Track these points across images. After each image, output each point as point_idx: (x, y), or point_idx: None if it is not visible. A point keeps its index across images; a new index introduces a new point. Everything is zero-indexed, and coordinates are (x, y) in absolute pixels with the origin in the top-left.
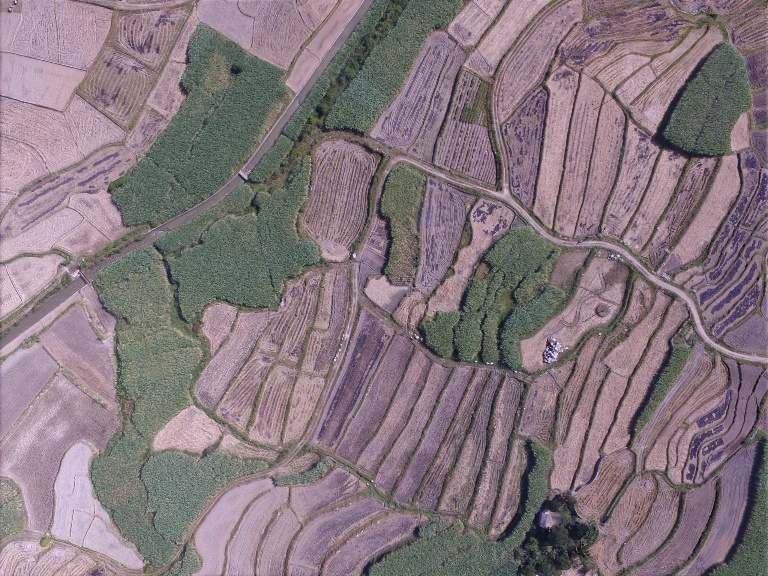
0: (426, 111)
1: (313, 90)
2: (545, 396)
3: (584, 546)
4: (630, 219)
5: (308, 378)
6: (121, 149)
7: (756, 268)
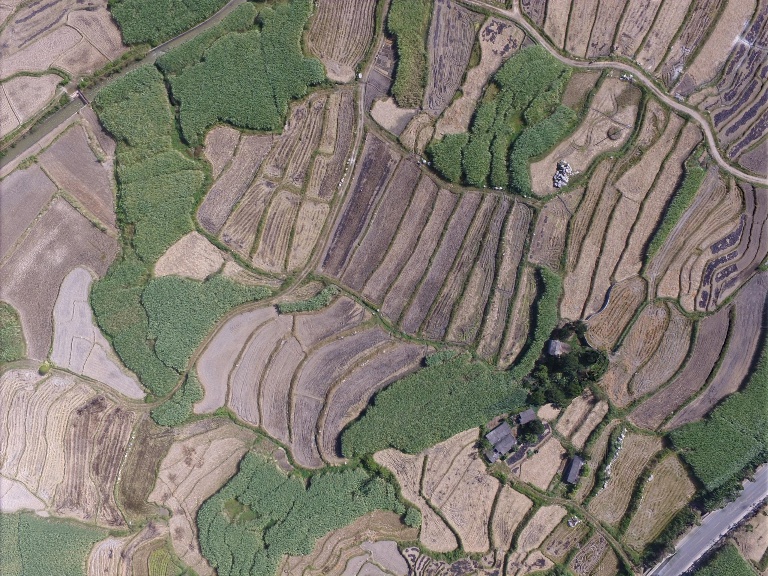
0: None
1: None
2: (555, 222)
3: (594, 376)
4: (643, 38)
5: (313, 204)
6: None
7: None
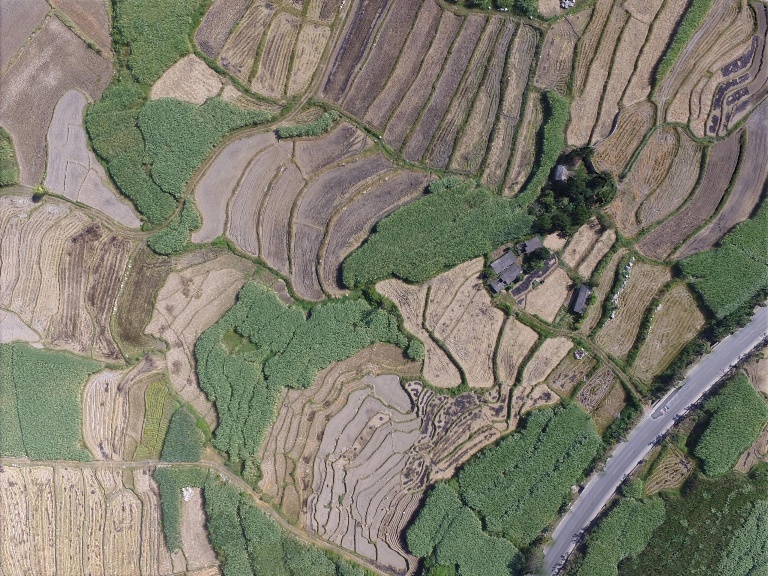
0: None
1: None
2: (562, 45)
3: (602, 204)
4: None
5: (313, 26)
6: None
7: None
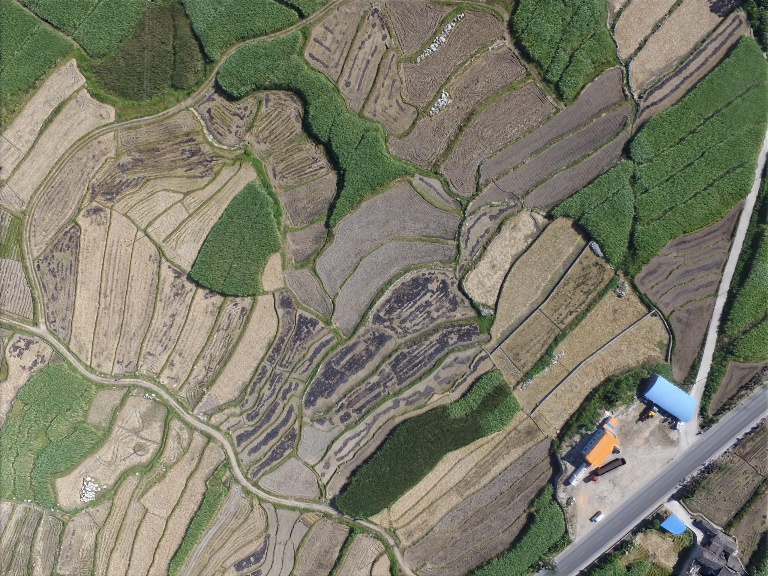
0: None
1: None
2: (83, 535)
3: None
4: (167, 357)
5: None
6: None
7: (293, 410)
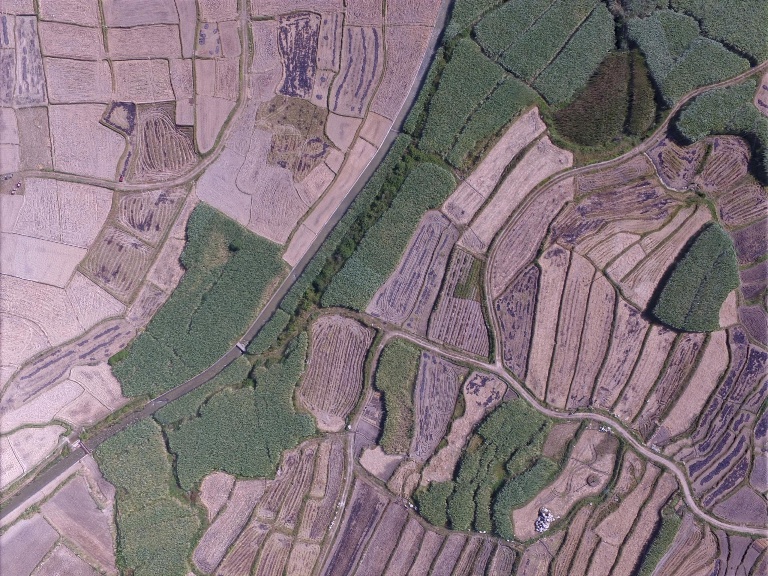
0: (420, 287)
1: (309, 266)
2: (537, 564)
3: None
4: (620, 392)
5: (304, 545)
6: (121, 322)
7: (744, 441)
